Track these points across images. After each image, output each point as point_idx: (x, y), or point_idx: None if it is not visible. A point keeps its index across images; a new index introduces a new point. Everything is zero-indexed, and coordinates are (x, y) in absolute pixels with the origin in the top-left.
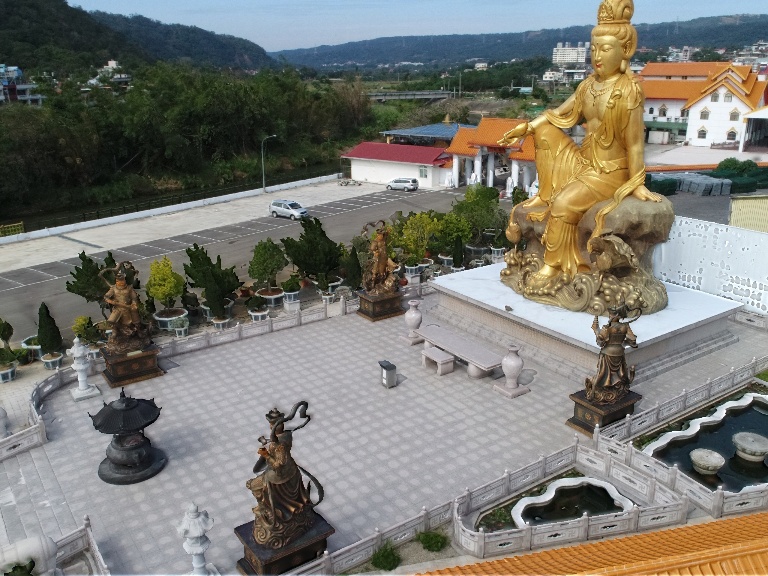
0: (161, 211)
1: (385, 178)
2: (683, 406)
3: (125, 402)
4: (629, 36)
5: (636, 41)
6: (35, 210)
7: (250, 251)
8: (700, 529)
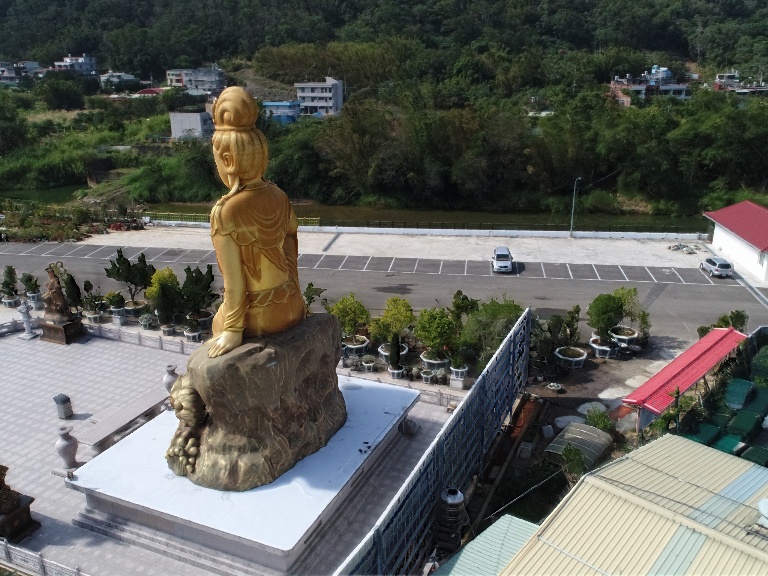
0: (441, 232)
1: (734, 253)
2: (41, 570)
3: None
4: (223, 147)
5: (236, 153)
6: (496, 208)
7: (373, 287)
8: None
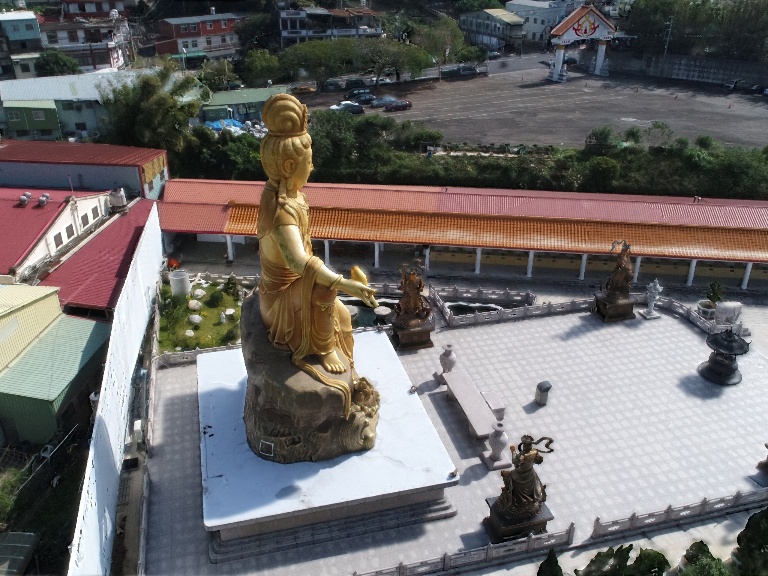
0: None
1: None
2: None
3: (728, 330)
4: None
5: None
6: None
7: None
8: (468, 241)
